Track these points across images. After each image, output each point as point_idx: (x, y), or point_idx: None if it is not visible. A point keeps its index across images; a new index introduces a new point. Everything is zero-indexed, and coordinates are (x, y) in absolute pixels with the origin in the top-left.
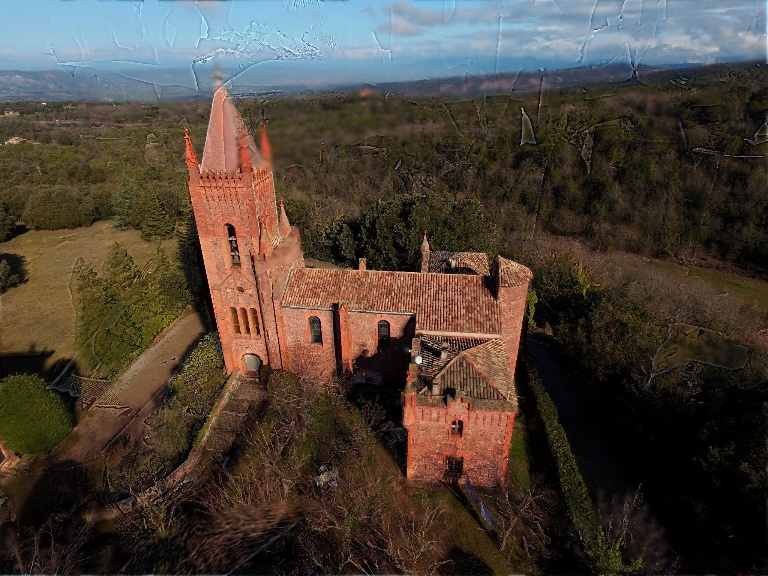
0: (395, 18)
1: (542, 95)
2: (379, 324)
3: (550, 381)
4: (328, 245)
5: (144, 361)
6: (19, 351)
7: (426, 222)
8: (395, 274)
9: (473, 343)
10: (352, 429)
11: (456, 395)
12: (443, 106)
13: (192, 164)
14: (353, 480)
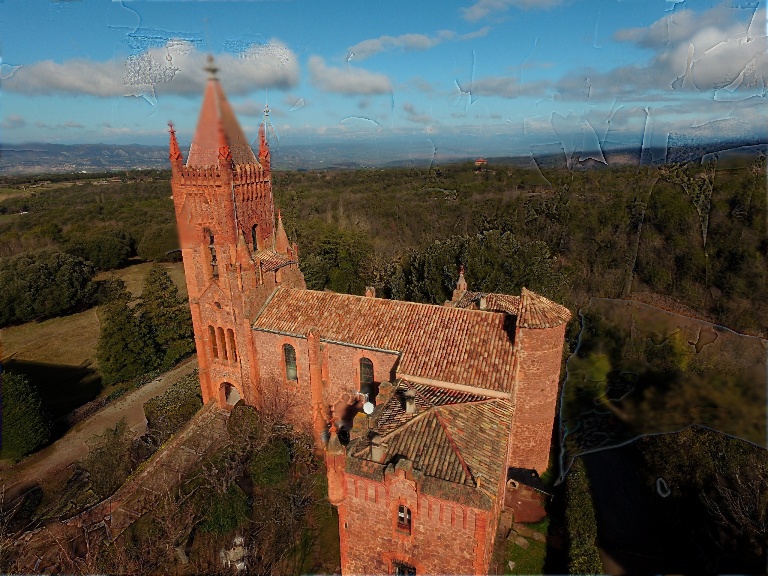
0: (477, 60)
1: (646, 136)
2: (362, 363)
3: (607, 479)
4: (380, 287)
5: (157, 383)
6: (65, 360)
7: (479, 264)
8: (391, 303)
9: (463, 399)
10: None
11: (396, 465)
12: (530, 153)
13: (175, 160)
14: (271, 567)
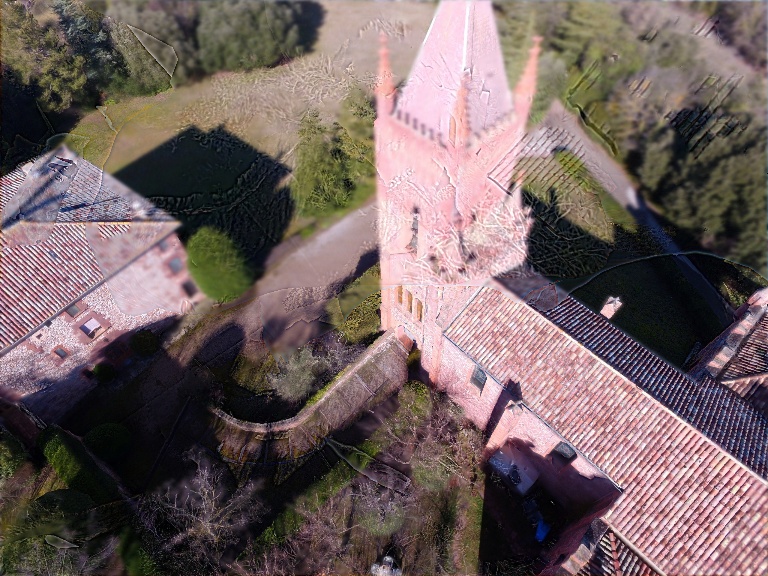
0: None
1: None
2: None
3: None
4: None
5: None
6: None
7: None
8: (638, 394)
9: None
10: (458, 516)
11: None
12: None
13: None
14: None
